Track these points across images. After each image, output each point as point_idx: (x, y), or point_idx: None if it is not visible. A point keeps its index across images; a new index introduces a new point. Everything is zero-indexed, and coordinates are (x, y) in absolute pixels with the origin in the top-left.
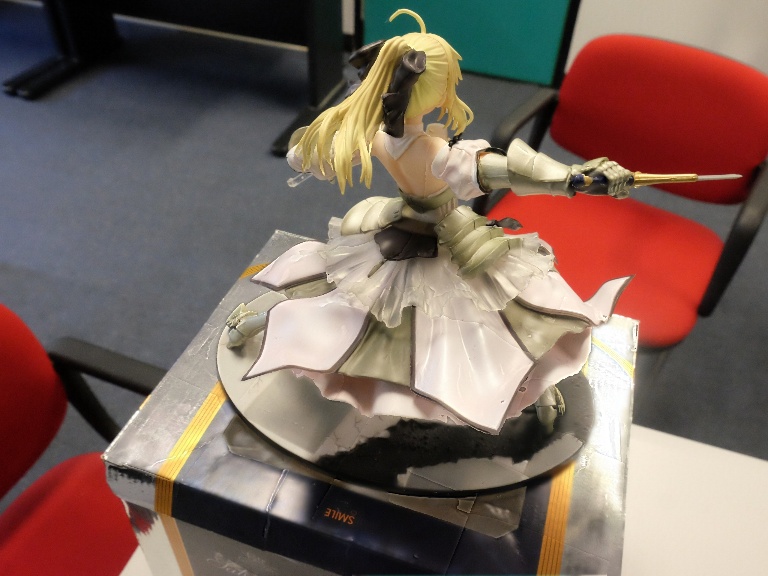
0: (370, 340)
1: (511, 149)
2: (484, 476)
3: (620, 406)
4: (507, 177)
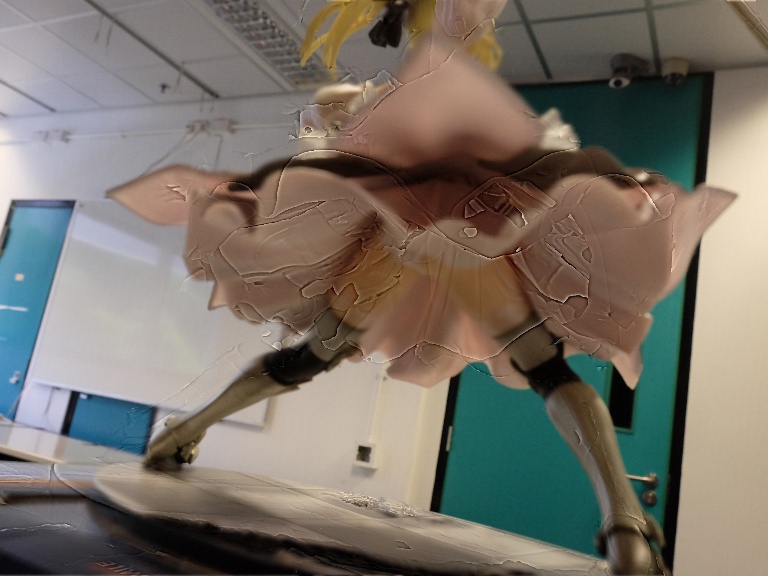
0: None
1: None
2: None
3: None
4: None
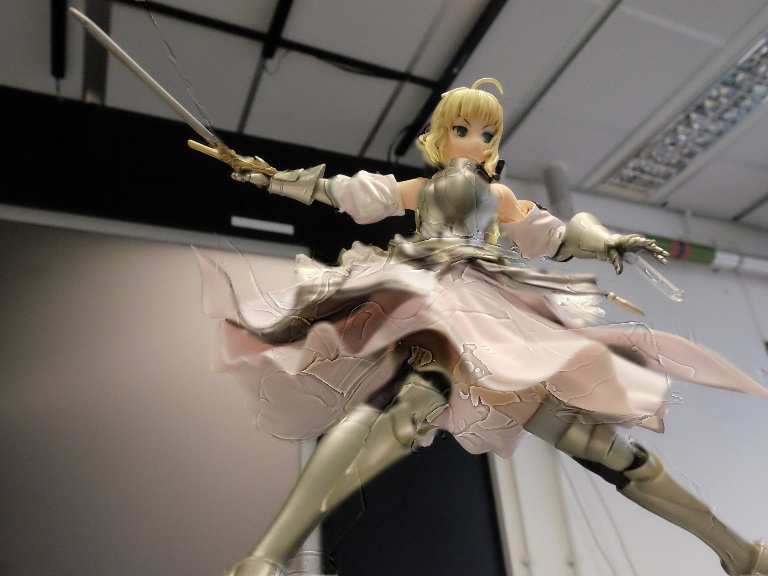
0: None
1: None
2: None
3: None
4: None
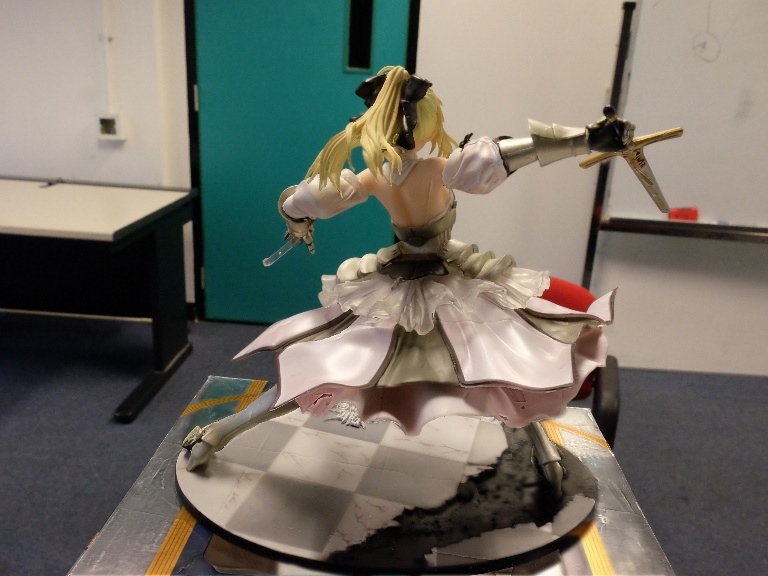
0: (402, 354)
1: (529, 121)
2: (514, 543)
3: (610, 471)
4: (526, 151)
